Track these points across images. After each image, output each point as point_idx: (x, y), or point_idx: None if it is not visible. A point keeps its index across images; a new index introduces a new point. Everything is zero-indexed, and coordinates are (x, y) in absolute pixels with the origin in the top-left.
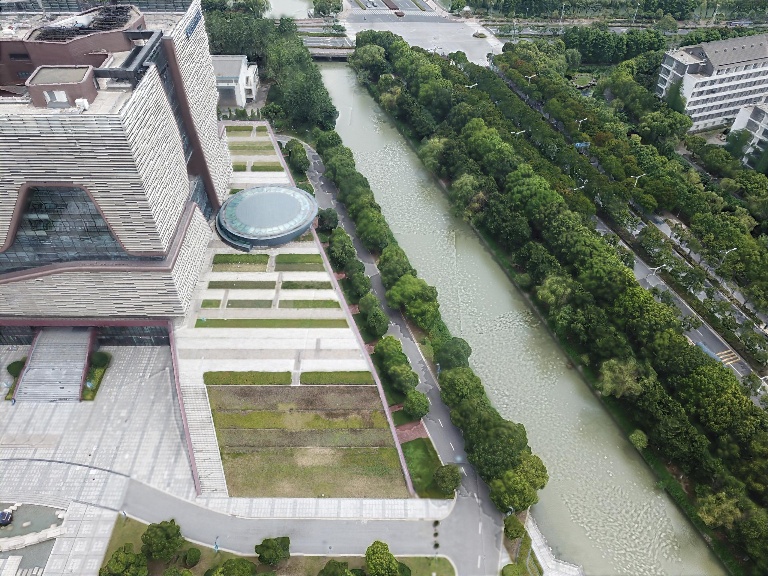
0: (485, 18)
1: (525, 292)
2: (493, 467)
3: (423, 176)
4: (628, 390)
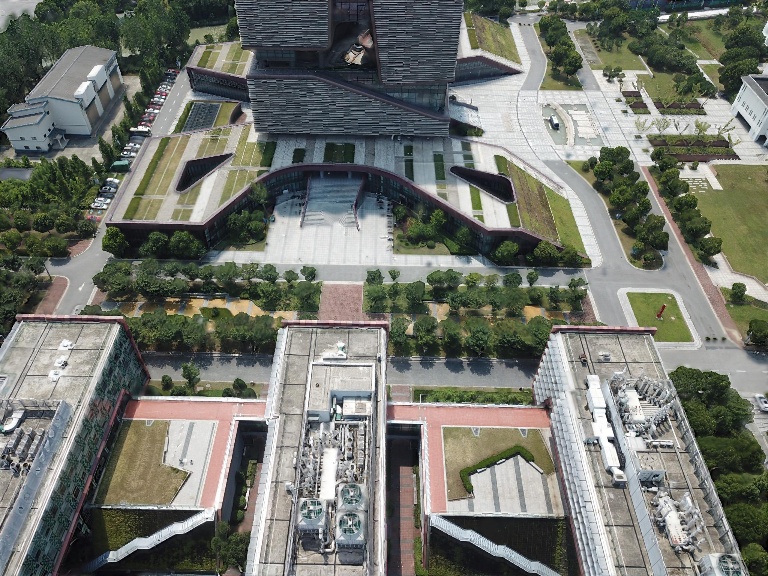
0: None
1: None
2: None
3: None
4: None
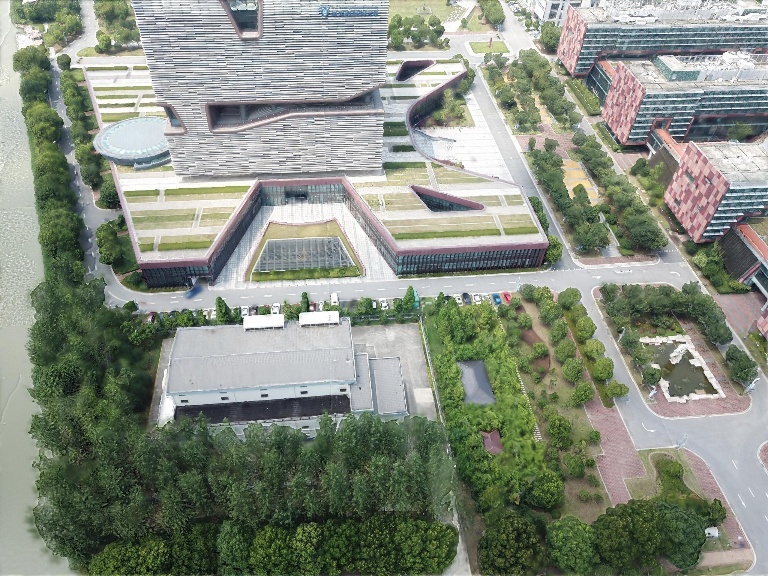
0: None
1: None
2: None
3: None
4: None
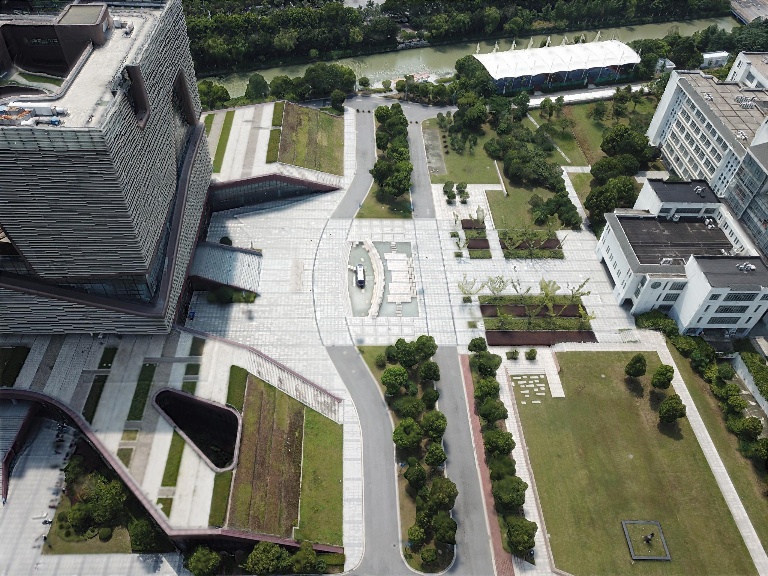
0: None
1: (197, 73)
2: (338, 75)
3: None
4: (295, 38)
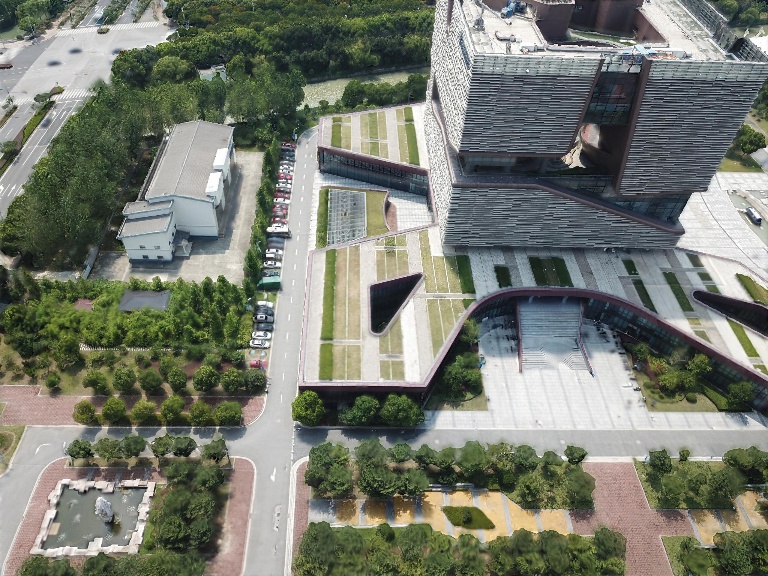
0: (71, 20)
1: None
2: None
3: (364, 79)
4: None
